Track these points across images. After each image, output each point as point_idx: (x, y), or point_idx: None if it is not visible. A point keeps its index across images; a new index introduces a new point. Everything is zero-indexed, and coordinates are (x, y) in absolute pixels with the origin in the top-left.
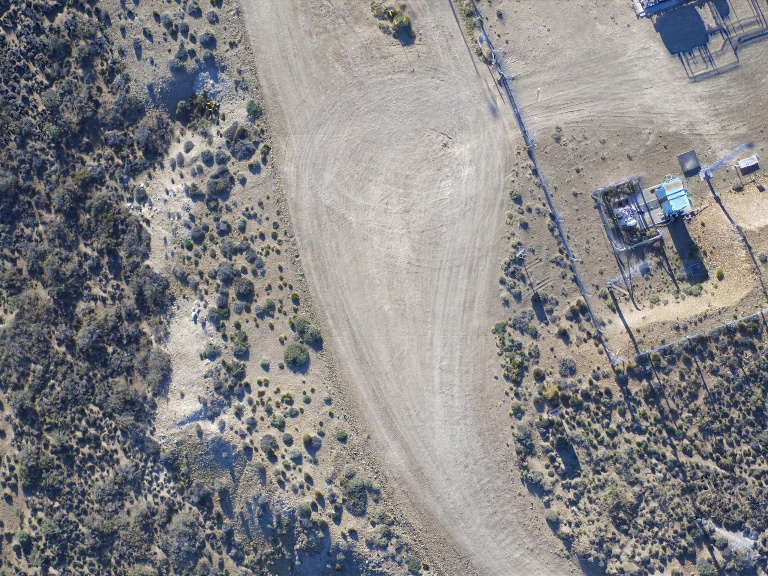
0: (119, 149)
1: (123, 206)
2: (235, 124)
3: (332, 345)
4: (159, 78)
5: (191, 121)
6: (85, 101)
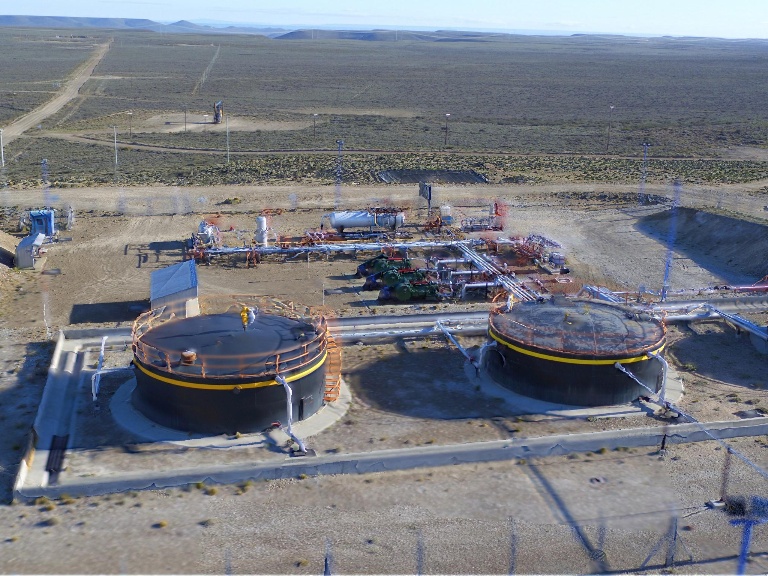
0: None
1: None
2: None
3: None
4: None
5: None
6: None
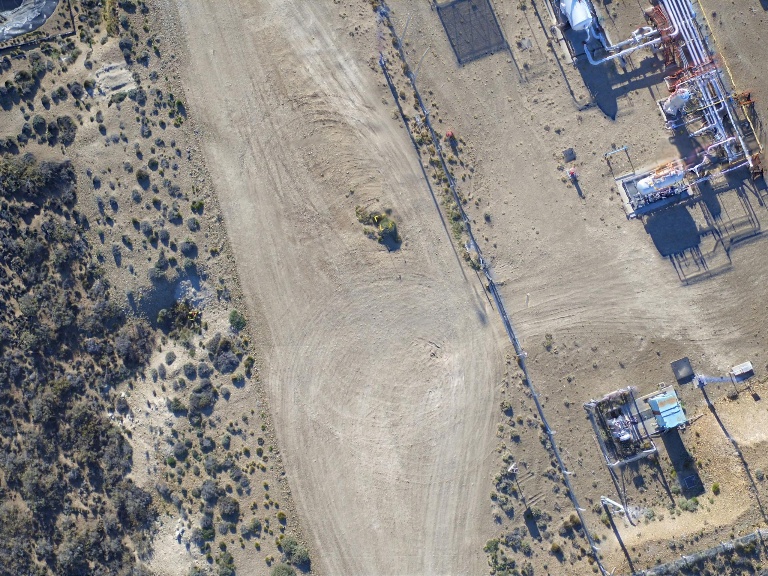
0: (99, 357)
1: (104, 416)
2: (218, 336)
3: (320, 566)
4: (139, 287)
5: (173, 330)
6: (63, 309)
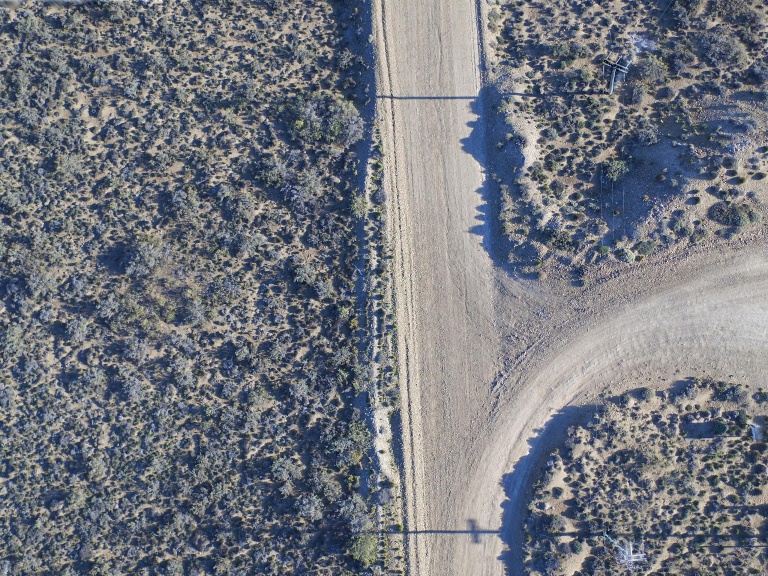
0: None
1: None
2: None
3: None
4: None
5: None
6: None
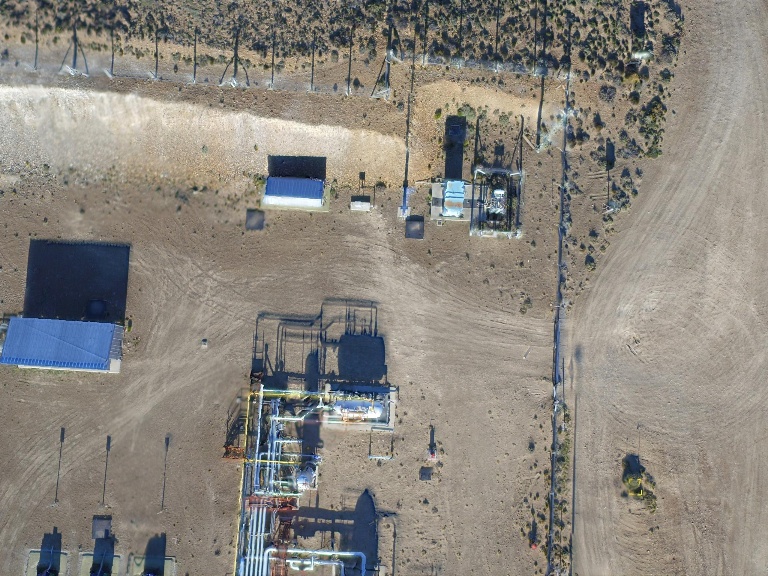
0: None
1: None
2: None
3: None
4: None
5: None
6: None
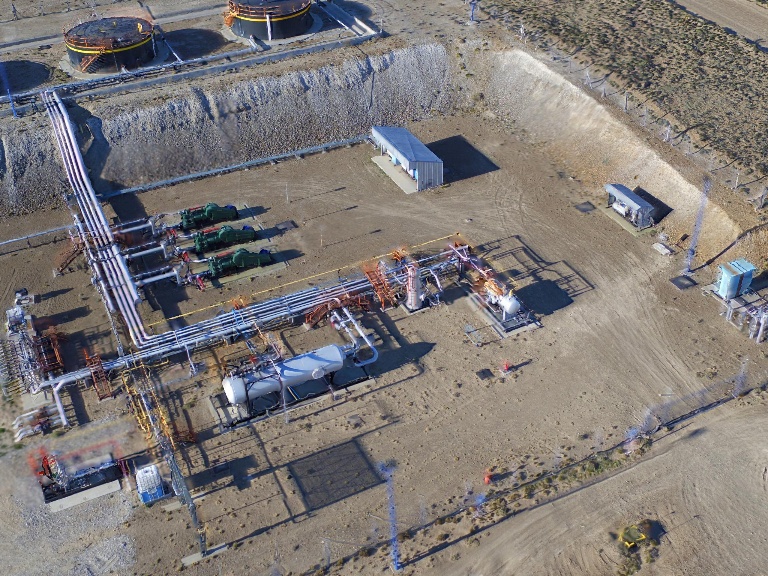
0: None
1: None
2: None
3: None
4: None
5: None
6: None
